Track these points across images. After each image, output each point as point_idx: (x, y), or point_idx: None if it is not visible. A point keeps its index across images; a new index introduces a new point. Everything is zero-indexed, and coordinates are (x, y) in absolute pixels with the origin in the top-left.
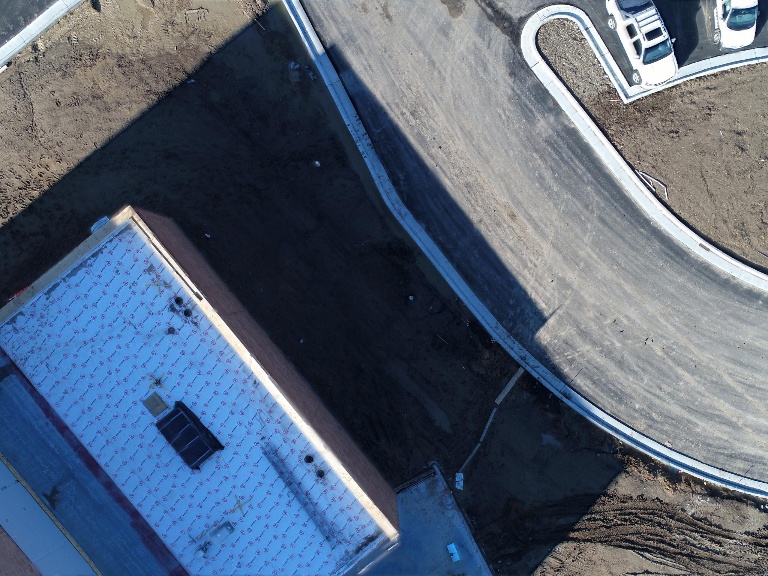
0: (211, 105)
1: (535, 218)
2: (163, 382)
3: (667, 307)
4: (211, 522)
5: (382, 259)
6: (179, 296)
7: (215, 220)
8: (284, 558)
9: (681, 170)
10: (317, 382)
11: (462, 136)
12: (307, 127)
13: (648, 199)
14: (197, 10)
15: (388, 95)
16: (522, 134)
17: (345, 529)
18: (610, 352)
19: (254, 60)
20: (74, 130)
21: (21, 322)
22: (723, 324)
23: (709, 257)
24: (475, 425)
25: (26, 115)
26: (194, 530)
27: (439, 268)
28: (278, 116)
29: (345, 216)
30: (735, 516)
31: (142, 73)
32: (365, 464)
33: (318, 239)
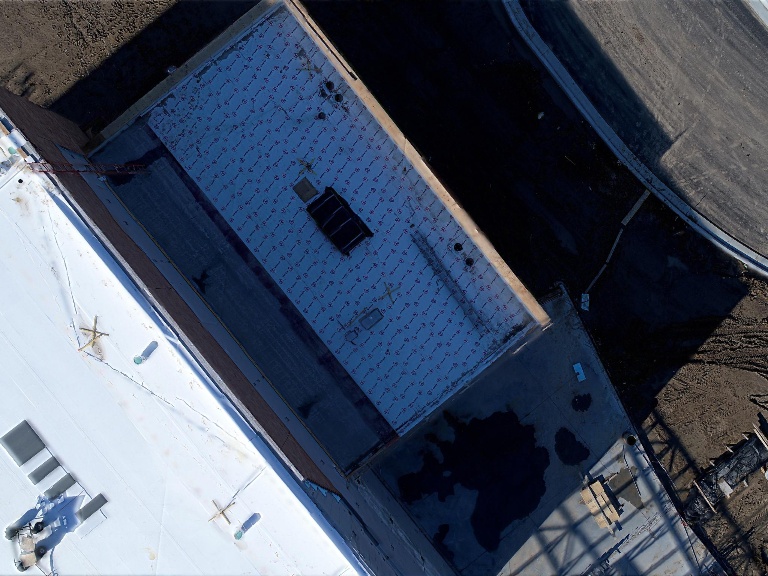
0: None
1: (663, 40)
2: (313, 168)
3: None
4: (360, 309)
5: (510, 78)
6: (330, 80)
7: (343, 37)
8: (432, 346)
9: None
10: None
11: None
12: None
13: None
14: None
15: None
16: None
17: (493, 318)
18: (736, 176)
19: None
20: None
21: (172, 105)
22: None
23: None
24: (601, 246)
25: None
26: (343, 316)
27: (566, 89)
28: None
29: (473, 35)
30: None
31: None
32: None
33: (446, 58)
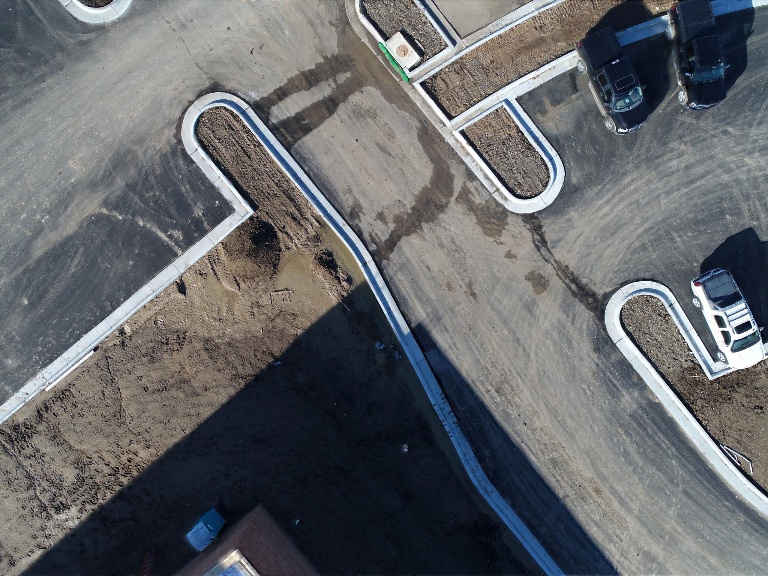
0: (297, 387)
1: (620, 493)
2: None
3: None
4: None
5: (469, 538)
6: None
7: (303, 503)
8: None
9: (766, 445)
10: None
11: (547, 412)
12: (393, 406)
13: (733, 473)
14: (282, 291)
15: (473, 373)
16: (607, 409)
17: None
18: None
19: (339, 341)
20: (162, 416)
21: None
22: None
23: None
24: None
25: (114, 400)
26: None
27: (526, 545)
28: (364, 396)
29: (432, 495)
30: None
31: (228, 356)
32: None
33: (405, 519)
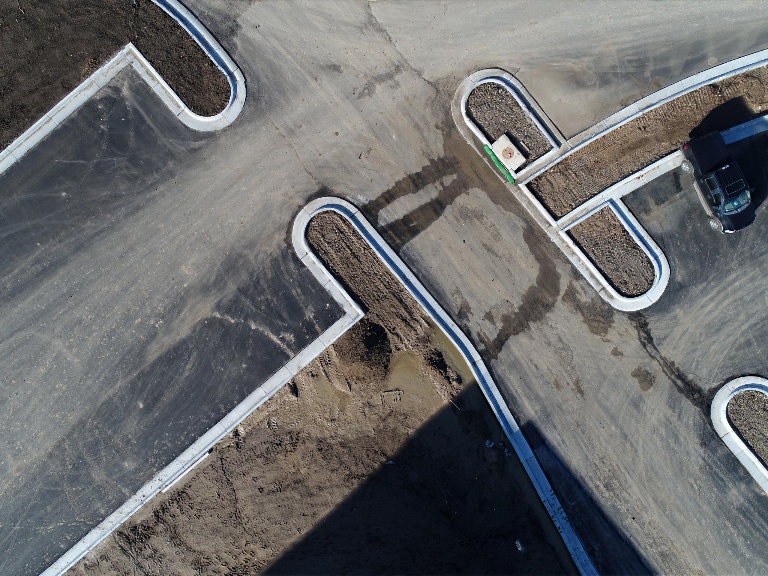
0: (409, 486)
1: None
2: None
3: None
4: None
5: None
6: None
7: None
8: None
9: None
10: None
11: (655, 507)
12: (503, 503)
13: None
14: (393, 392)
15: (581, 469)
16: (713, 503)
17: None
18: None
19: (450, 439)
20: (278, 517)
21: None
22: None
23: None
24: None
25: (229, 502)
26: None
27: None
28: (475, 494)
29: None
30: None
31: (341, 456)
32: None
33: None
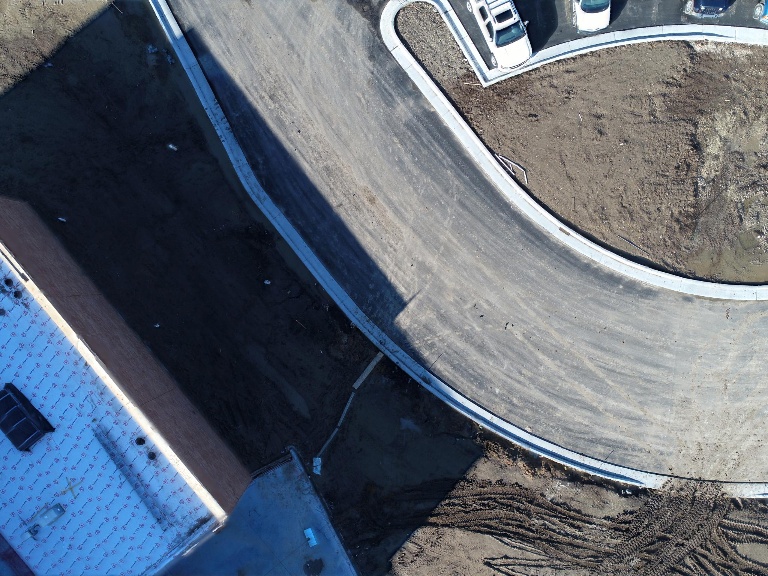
0: (68, 89)
1: (395, 202)
2: None
3: (527, 292)
4: (42, 504)
5: (240, 243)
6: (9, 278)
7: (71, 204)
8: (115, 540)
9: (540, 154)
10: (174, 367)
11: (321, 120)
12: (165, 111)
13: (508, 183)
14: None
15: (247, 79)
16: (382, 118)
17: (177, 511)
18: (470, 337)
19: (112, 44)
20: None
21: None
22: (584, 309)
23: (569, 241)
24: (333, 410)
25: None
26: (25, 512)
27: (297, 252)
28: (136, 100)
29: (203, 200)
30: (595, 501)
31: None
32: (216, 448)
33: (176, 223)
